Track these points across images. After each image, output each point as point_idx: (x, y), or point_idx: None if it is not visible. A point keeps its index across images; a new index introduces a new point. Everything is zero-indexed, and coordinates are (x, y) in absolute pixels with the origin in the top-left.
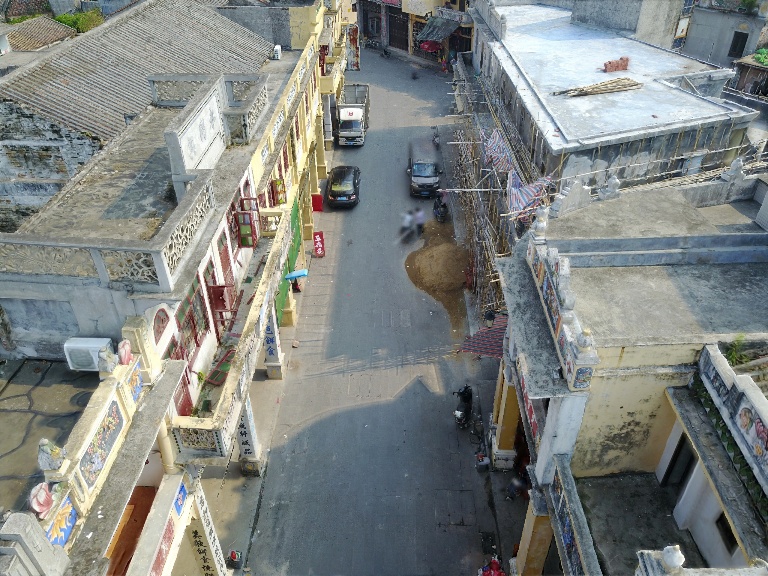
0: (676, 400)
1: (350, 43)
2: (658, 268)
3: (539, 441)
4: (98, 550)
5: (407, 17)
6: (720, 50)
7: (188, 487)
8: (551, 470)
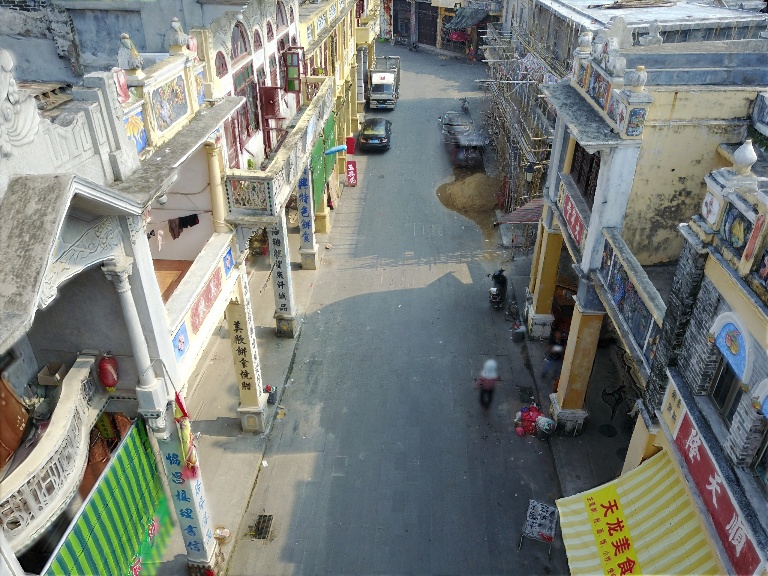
0: (730, 150)
1: (384, 11)
2: (703, 86)
3: (585, 239)
4: (167, 164)
5: (436, 13)
6: None
7: (235, 258)
8: (599, 249)
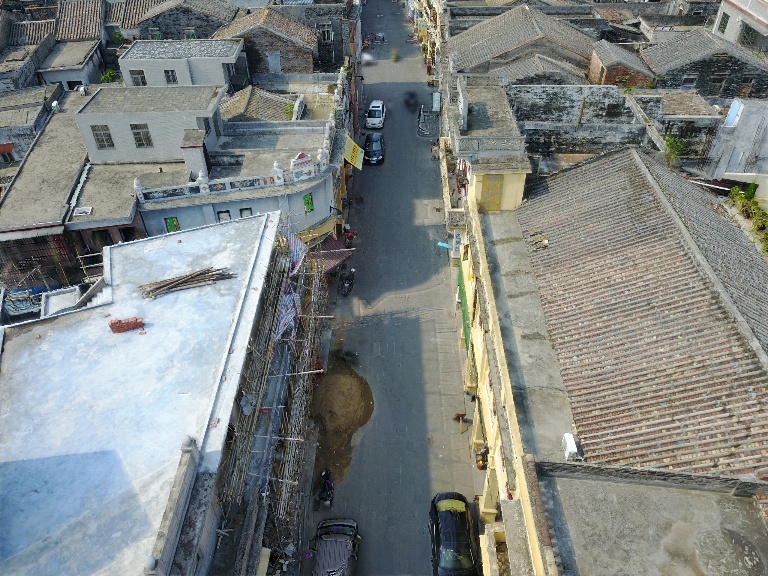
0: None
1: None
2: None
3: None
4: None
5: None
6: None
7: None
8: None
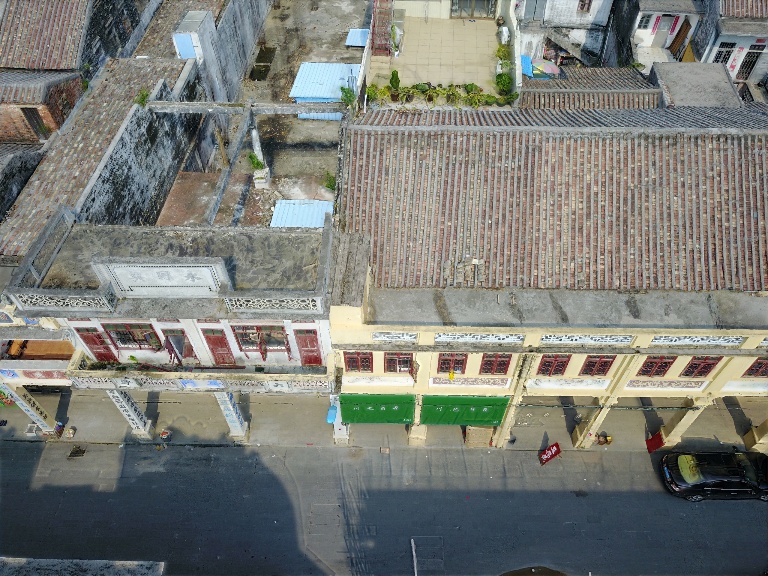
0: None
1: None
2: None
3: None
4: None
5: None
6: None
7: None
8: None
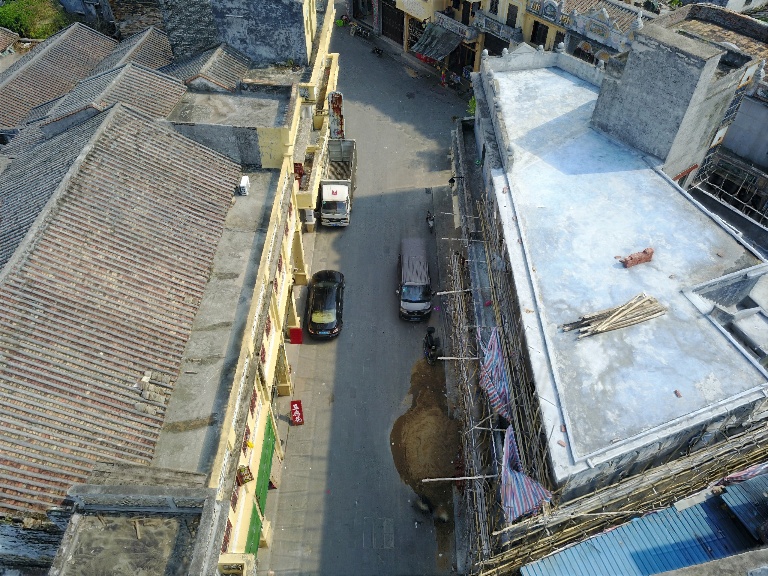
0: None
1: (333, 111)
2: None
3: None
4: None
5: None
6: (760, 145)
7: None
8: None
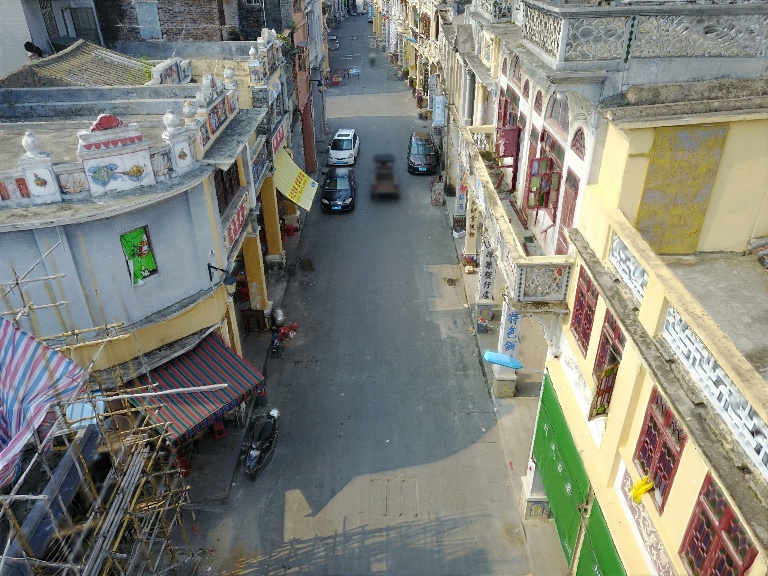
0: None
1: None
2: None
3: None
4: None
5: None
6: None
7: None
8: None
